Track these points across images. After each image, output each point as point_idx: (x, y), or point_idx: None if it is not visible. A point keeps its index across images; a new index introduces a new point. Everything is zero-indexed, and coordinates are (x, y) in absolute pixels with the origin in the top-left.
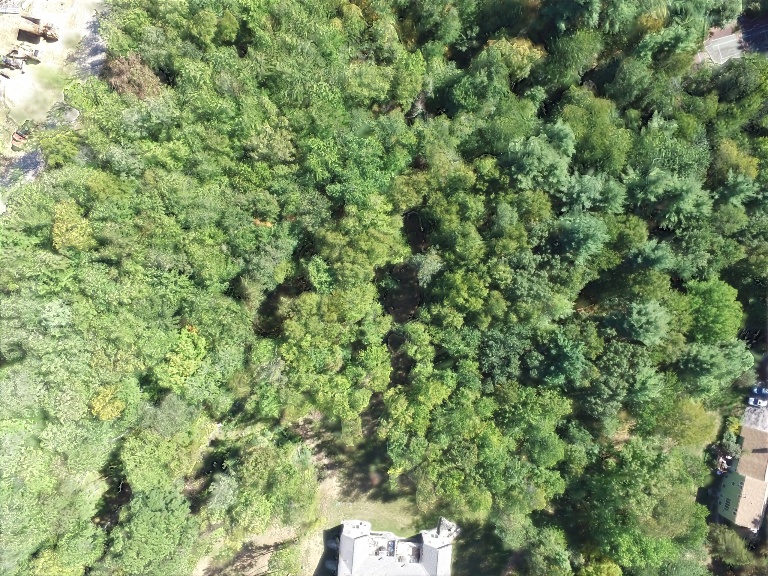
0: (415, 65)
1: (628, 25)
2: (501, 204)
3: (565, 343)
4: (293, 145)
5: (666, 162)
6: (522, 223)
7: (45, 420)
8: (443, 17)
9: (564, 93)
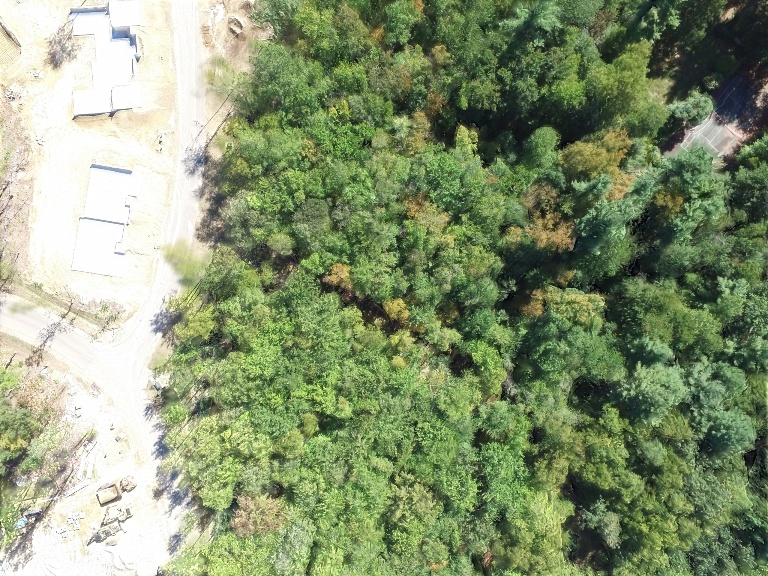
0: (495, 366)
1: (648, 210)
2: (648, 451)
3: (767, 528)
4: (426, 488)
5: (762, 327)
6: (671, 450)
7: None
8: (482, 295)
9: (624, 297)
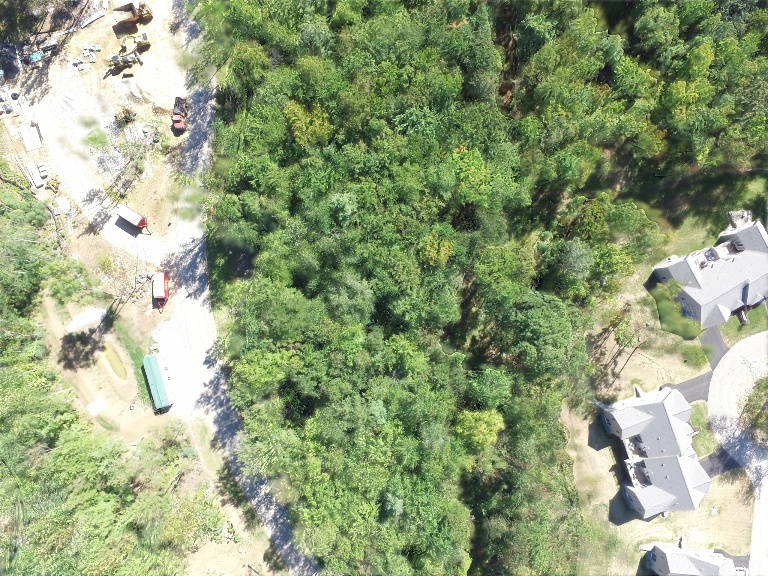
0: None
1: None
2: None
3: None
4: None
5: None
6: None
7: (384, 311)
8: None
9: None
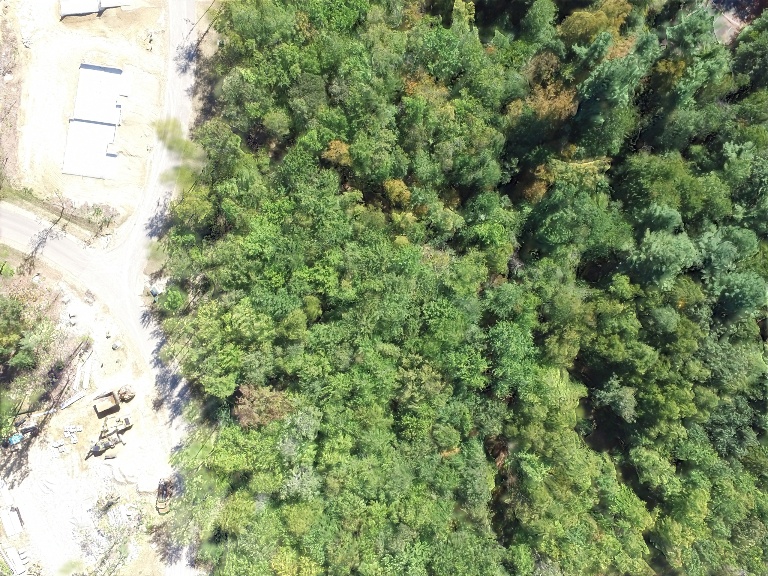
0: (501, 239)
1: (650, 79)
2: (661, 316)
3: None
4: (434, 371)
5: None
6: (684, 317)
7: None
8: (485, 173)
9: (630, 171)
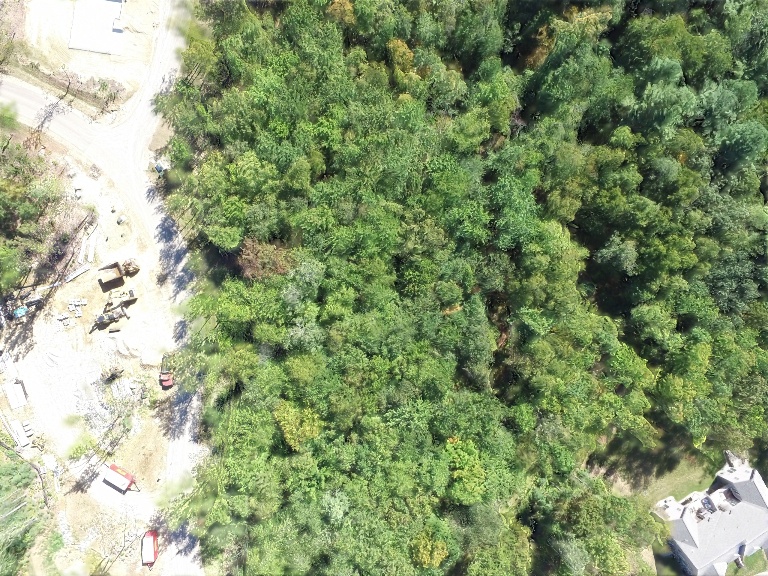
0: (503, 92)
1: None
2: (662, 164)
3: None
4: None
5: None
6: (685, 168)
7: None
8: (487, 34)
9: (631, 34)
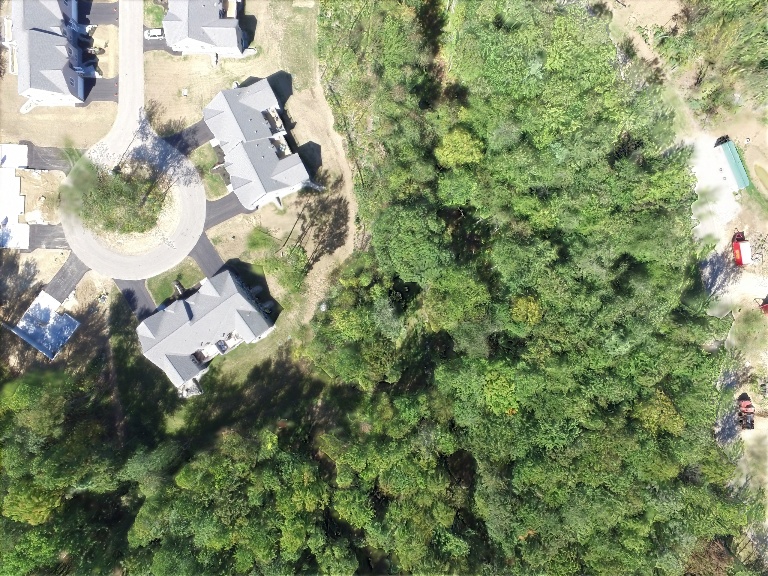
0: None
1: None
2: None
3: None
4: None
5: None
6: None
7: (560, 250)
8: None
9: None
